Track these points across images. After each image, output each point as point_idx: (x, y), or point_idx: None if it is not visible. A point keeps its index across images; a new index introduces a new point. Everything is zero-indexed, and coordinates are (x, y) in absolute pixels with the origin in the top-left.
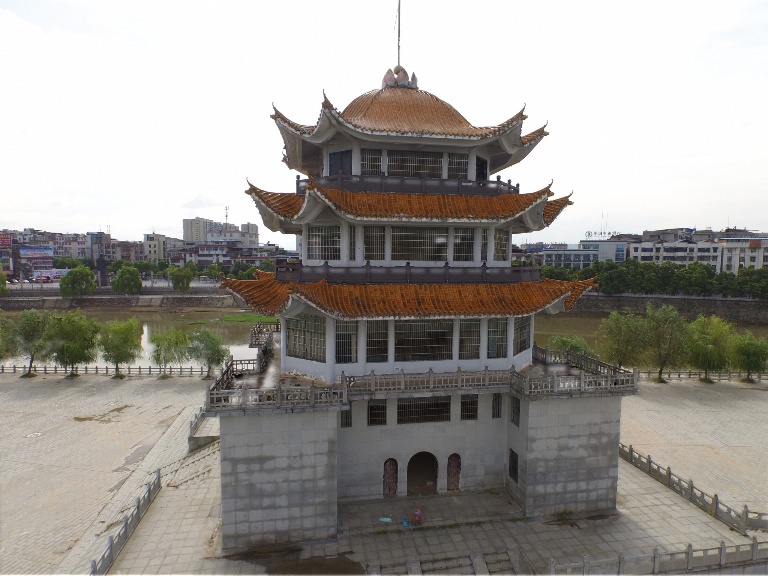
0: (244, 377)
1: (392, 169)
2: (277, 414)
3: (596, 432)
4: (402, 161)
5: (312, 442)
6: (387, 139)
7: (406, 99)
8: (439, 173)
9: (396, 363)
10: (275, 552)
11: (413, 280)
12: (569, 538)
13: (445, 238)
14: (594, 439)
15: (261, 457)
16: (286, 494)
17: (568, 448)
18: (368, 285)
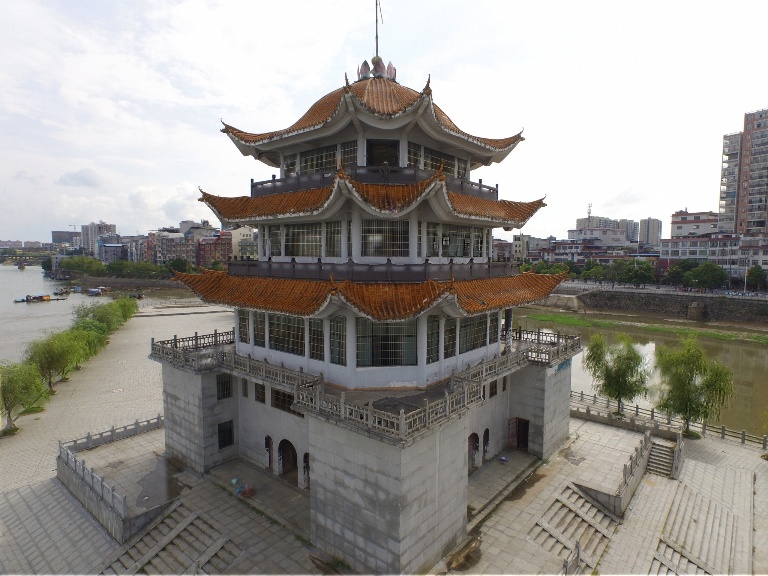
0: (231, 344)
1: (303, 170)
2: (170, 366)
3: (372, 481)
4: (309, 161)
5: (192, 395)
6: (273, 146)
7: (337, 96)
8: (334, 166)
9: (270, 350)
10: (173, 466)
11: (271, 274)
12: None
13: (320, 233)
14: (370, 489)
15: (175, 396)
16: (184, 428)
17: (344, 486)
18: (245, 277)
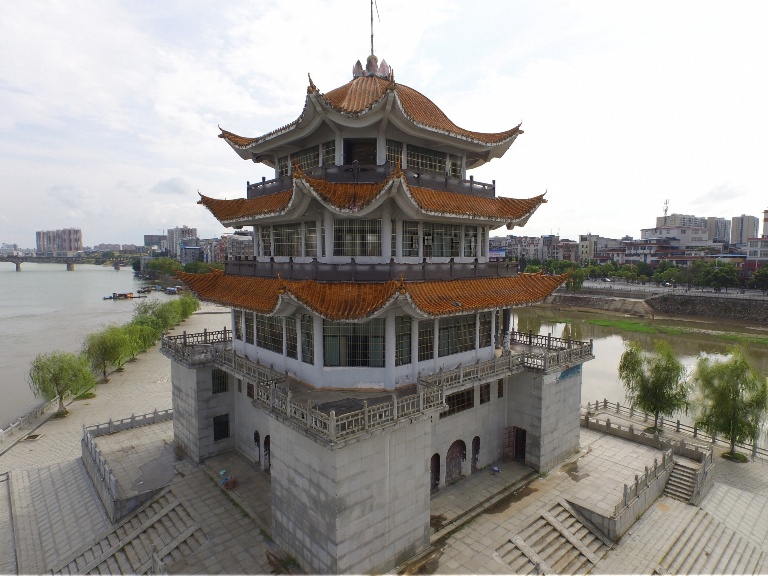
0: None
1: None
2: None
3: (315, 481)
4: (297, 162)
5: (190, 388)
6: (262, 148)
7: None
8: None
9: (257, 347)
10: (176, 454)
11: (256, 274)
12: (246, 573)
13: (300, 233)
14: (314, 489)
15: (179, 388)
16: None
17: (295, 484)
18: (237, 276)
